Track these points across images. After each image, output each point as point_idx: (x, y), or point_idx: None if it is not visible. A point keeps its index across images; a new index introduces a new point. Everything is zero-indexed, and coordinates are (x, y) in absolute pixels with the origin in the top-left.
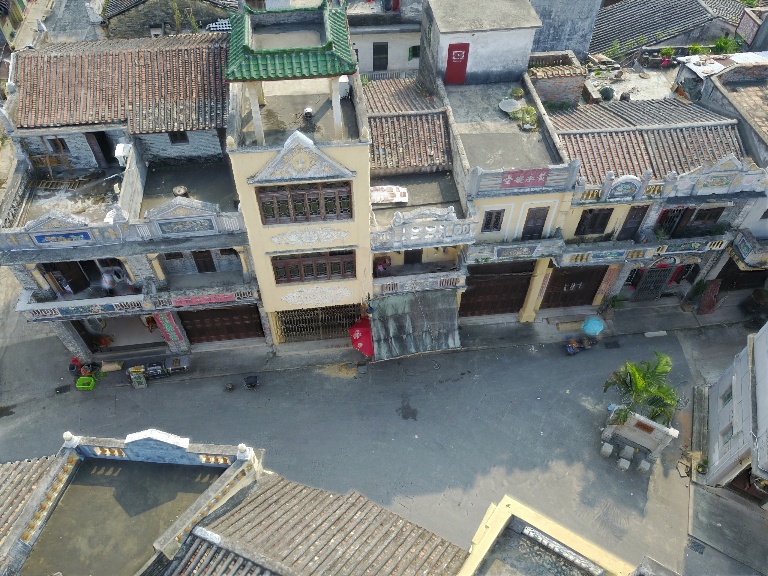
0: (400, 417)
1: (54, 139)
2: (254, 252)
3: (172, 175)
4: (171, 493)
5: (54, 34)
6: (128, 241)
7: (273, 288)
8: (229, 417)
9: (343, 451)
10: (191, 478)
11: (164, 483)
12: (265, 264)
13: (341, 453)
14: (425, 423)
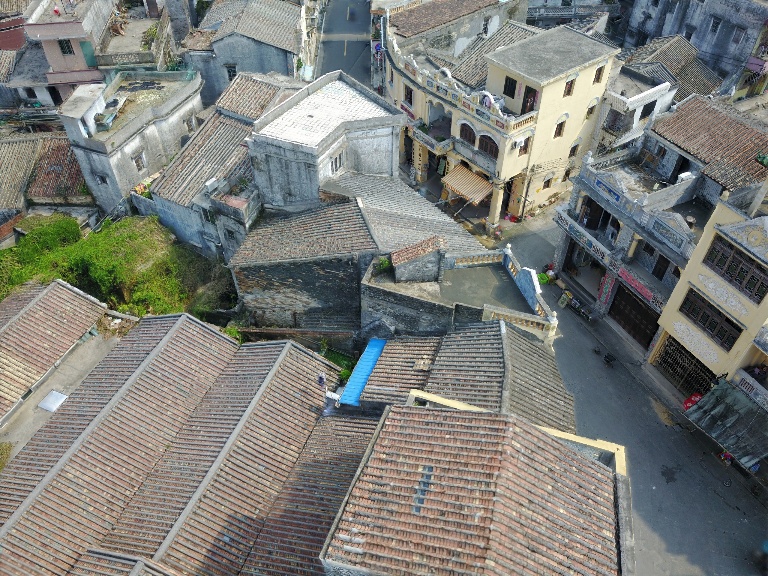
0: (660, 470)
1: (662, 147)
2: (683, 275)
3: (700, 212)
4: (512, 306)
5: (767, 114)
6: (633, 218)
7: (674, 310)
8: (577, 360)
9: (605, 439)
10: (524, 310)
11: (514, 301)
12: (683, 289)
13: (603, 439)
14: (670, 491)
